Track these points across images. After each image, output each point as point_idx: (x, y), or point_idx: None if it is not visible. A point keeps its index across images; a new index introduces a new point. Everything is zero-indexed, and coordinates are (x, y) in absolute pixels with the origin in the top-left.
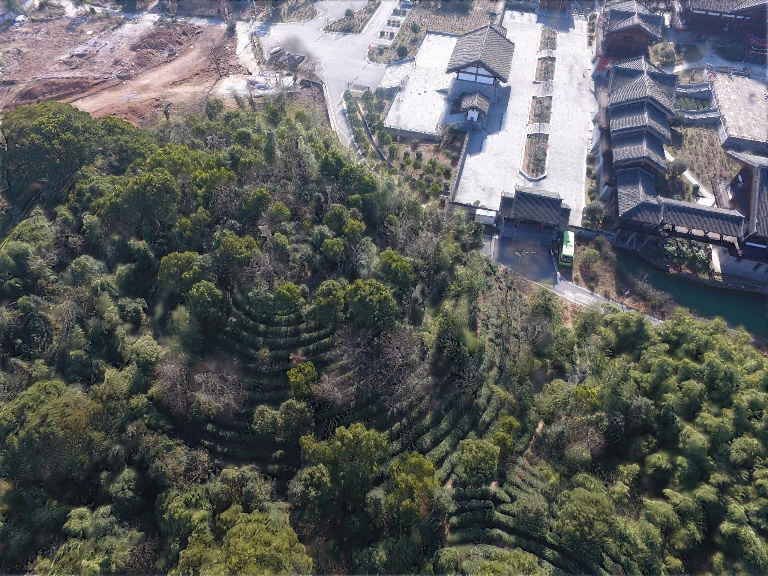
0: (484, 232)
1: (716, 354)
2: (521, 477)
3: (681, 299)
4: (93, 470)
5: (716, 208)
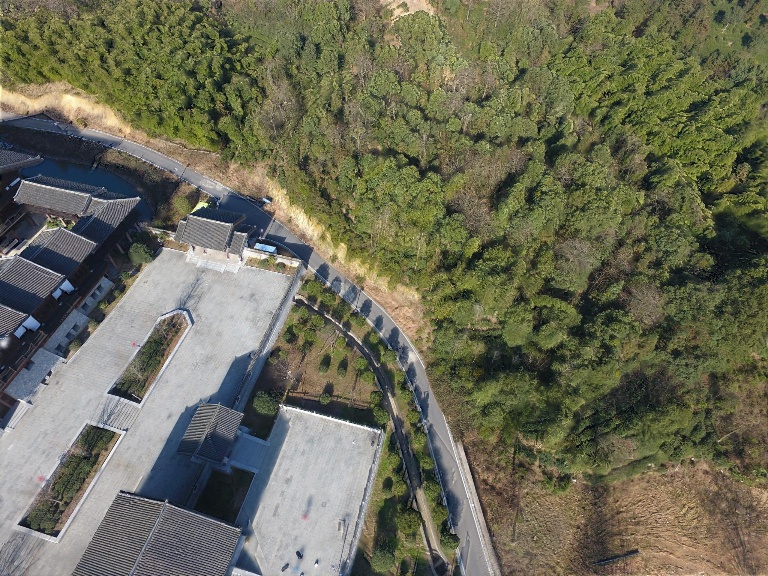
0: (272, 242)
1: (171, 87)
2: (307, 75)
3: (121, 191)
4: (513, 81)
5: (33, 200)
